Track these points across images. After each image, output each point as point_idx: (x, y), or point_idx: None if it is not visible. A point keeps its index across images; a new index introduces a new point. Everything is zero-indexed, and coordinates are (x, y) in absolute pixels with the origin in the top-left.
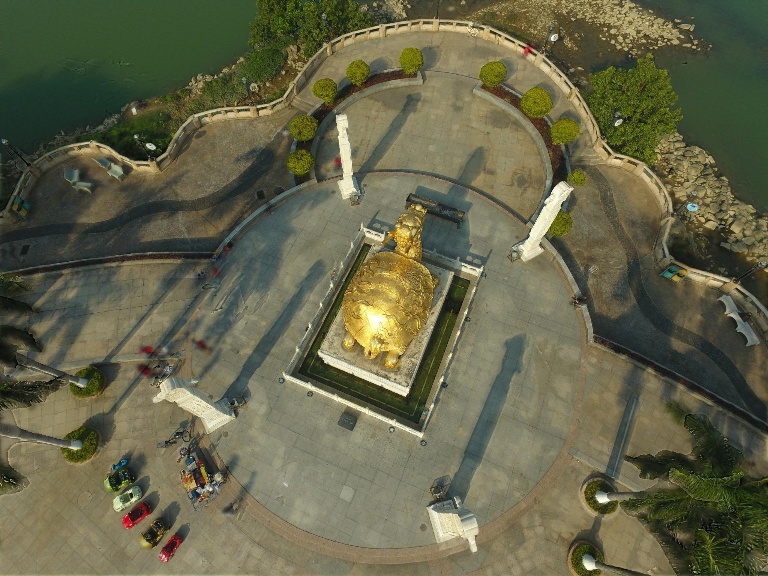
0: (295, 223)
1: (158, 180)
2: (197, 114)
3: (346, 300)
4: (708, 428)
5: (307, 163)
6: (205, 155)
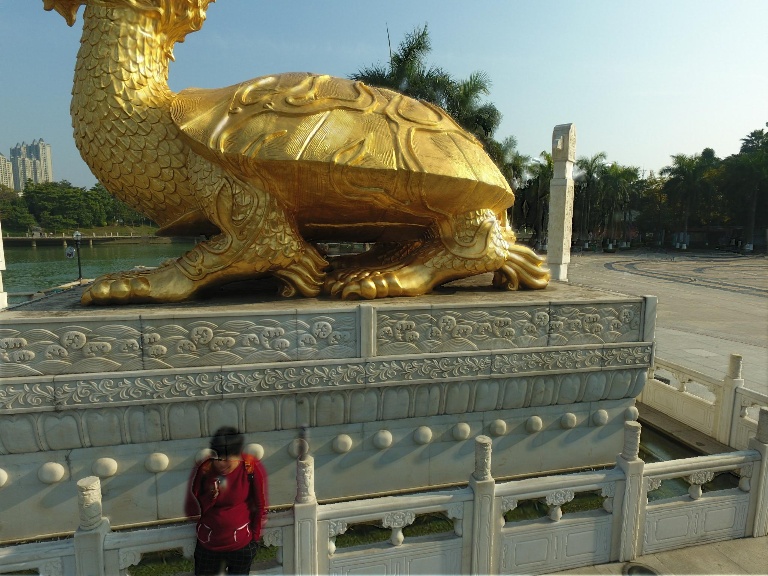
0: None
1: None
2: None
3: (447, 150)
4: (366, 74)
5: None
6: None
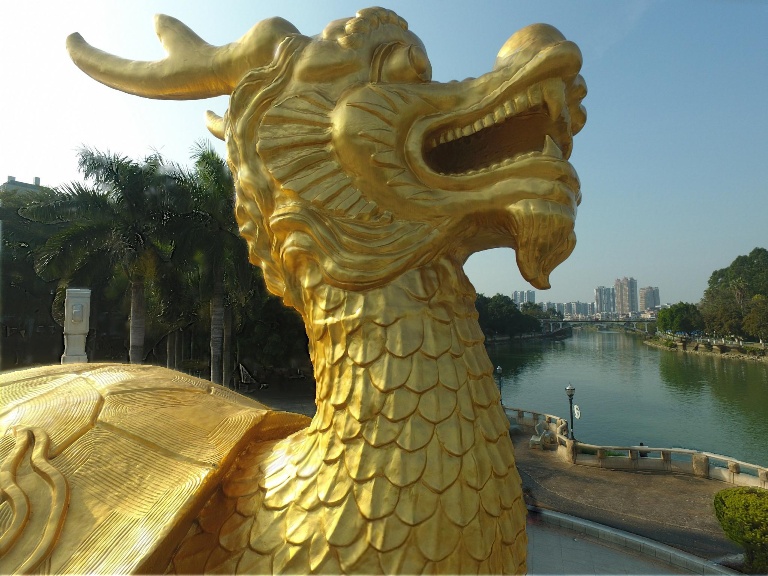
0: (578, 575)
1: (557, 464)
2: (710, 453)
3: None
4: None
5: (767, 508)
6: (652, 487)
